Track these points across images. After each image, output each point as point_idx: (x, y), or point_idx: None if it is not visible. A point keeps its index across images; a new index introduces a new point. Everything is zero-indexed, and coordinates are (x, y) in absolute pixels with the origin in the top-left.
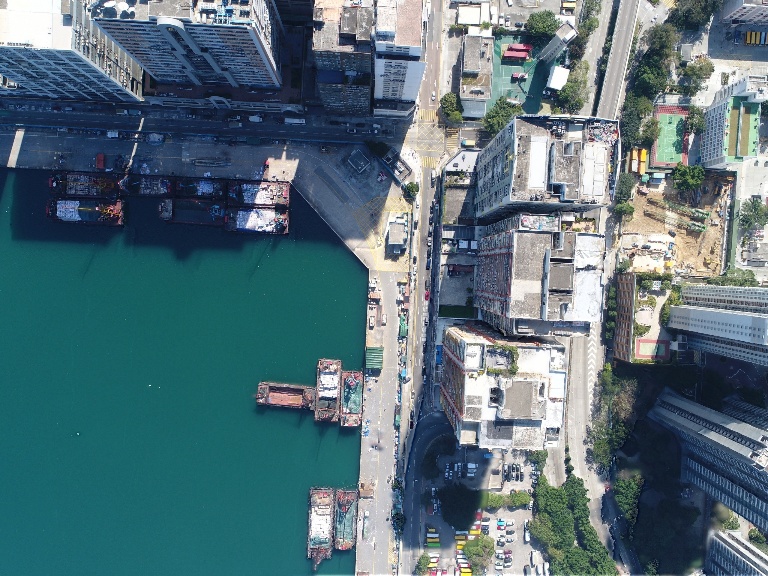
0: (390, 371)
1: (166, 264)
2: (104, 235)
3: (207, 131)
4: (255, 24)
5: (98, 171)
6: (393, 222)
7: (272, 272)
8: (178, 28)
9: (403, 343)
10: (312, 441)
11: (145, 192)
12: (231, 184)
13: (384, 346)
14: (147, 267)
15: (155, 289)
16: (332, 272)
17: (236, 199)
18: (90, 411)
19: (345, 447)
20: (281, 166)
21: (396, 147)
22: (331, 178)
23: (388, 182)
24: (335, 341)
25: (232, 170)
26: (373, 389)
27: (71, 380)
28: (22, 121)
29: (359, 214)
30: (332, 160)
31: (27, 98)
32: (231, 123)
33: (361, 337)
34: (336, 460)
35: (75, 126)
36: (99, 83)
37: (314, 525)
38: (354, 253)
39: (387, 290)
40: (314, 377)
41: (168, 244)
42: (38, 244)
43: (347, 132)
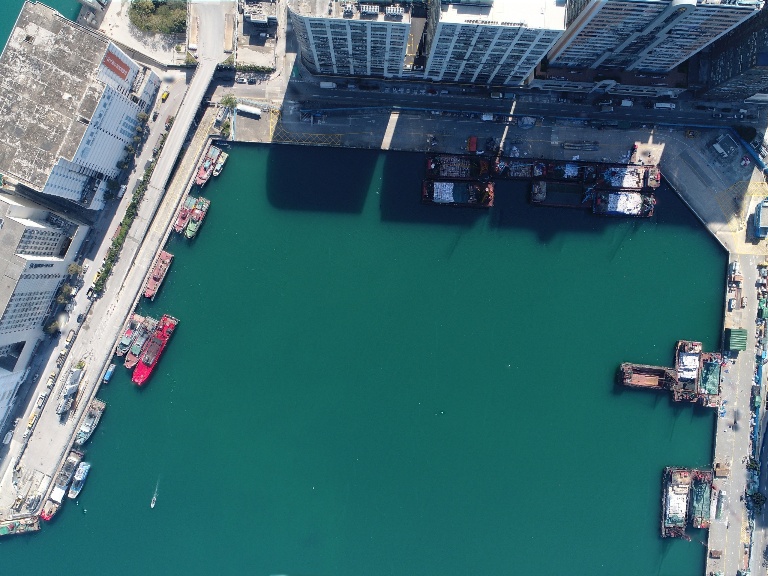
0: (747, 353)
1: (531, 246)
2: (469, 217)
3: (577, 115)
4: (762, 5)
5: (469, 154)
6: (763, 206)
7: (634, 254)
8: (692, 8)
9: (761, 325)
10: (666, 421)
11: (514, 175)
12: (599, 167)
13: (743, 328)
14: (513, 249)
15: (518, 270)
16: (692, 255)
17: (607, 182)
18: (453, 390)
19: (699, 428)
20: (647, 150)
21: (761, 132)
22: (695, 162)
23: (751, 166)
24: (693, 323)
25: (599, 154)
26: (730, 370)
27: (435, 360)
28: (397, 104)
29: (722, 198)
30: (697, 144)
31: (409, 81)
32: (604, 107)
33: (717, 319)
34: (690, 440)
35: (451, 109)
36: (517, 65)
37: (672, 504)
38: (715, 236)
39: (747, 273)
40: (672, 358)
41: (531, 226)
42: (404, 225)
43: (713, 117)
